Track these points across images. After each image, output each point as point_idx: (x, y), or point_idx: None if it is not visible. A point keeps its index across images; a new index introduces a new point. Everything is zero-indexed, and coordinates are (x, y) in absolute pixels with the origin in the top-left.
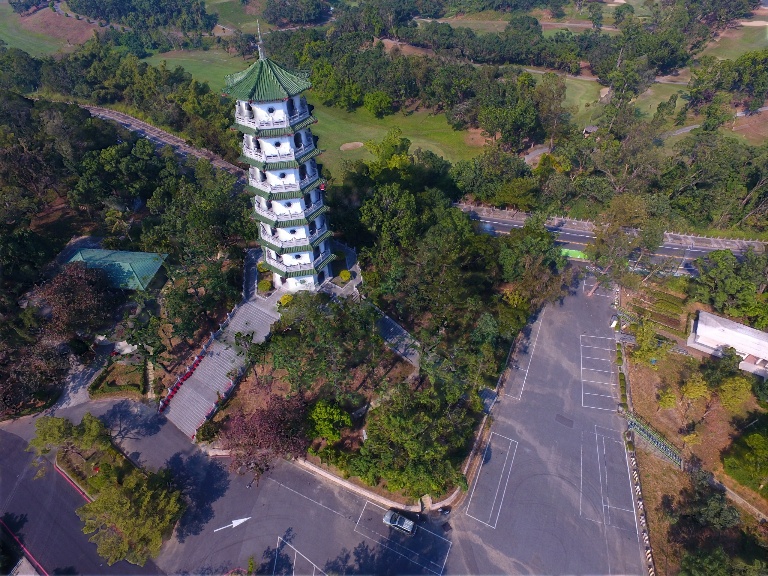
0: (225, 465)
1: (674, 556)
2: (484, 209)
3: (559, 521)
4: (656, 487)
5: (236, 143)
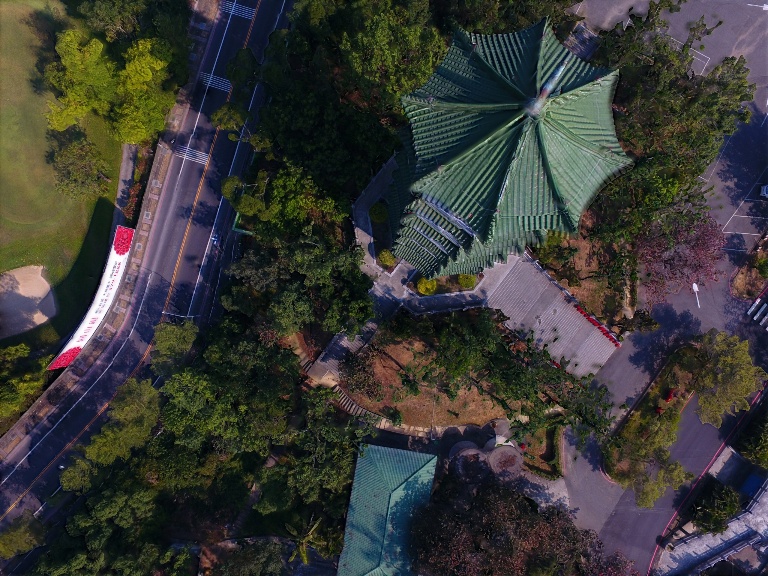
0: None
1: None
2: None
3: (705, 1)
4: None
5: (10, 400)
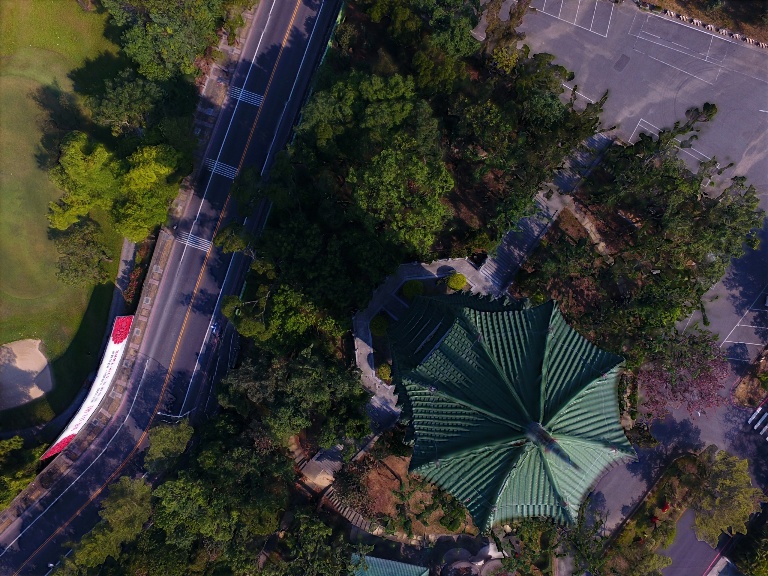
0: (644, 416)
1: (724, 21)
2: (223, 48)
3: (717, 105)
4: (669, 6)
5: (1, 499)
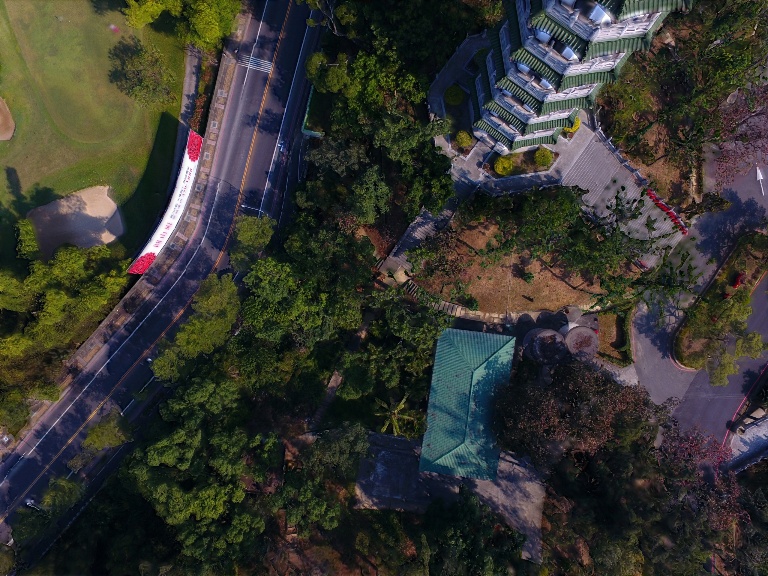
0: None
1: None
2: None
3: None
4: None
5: (99, 294)
